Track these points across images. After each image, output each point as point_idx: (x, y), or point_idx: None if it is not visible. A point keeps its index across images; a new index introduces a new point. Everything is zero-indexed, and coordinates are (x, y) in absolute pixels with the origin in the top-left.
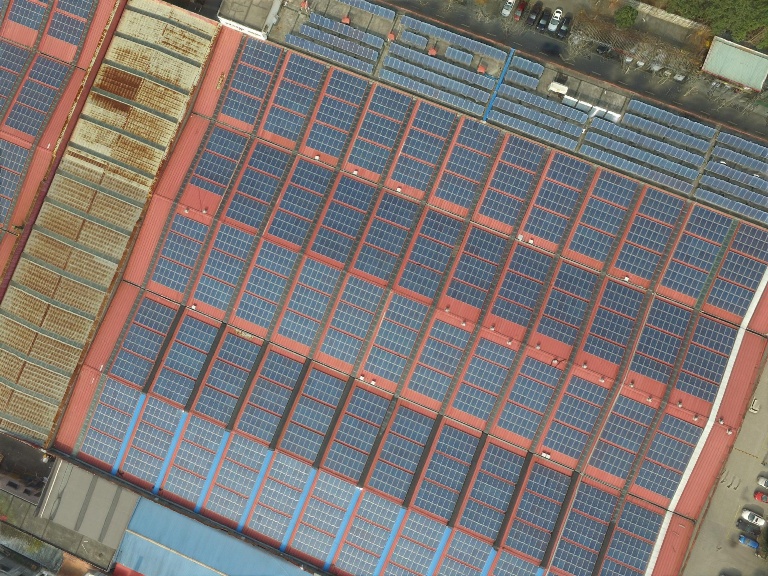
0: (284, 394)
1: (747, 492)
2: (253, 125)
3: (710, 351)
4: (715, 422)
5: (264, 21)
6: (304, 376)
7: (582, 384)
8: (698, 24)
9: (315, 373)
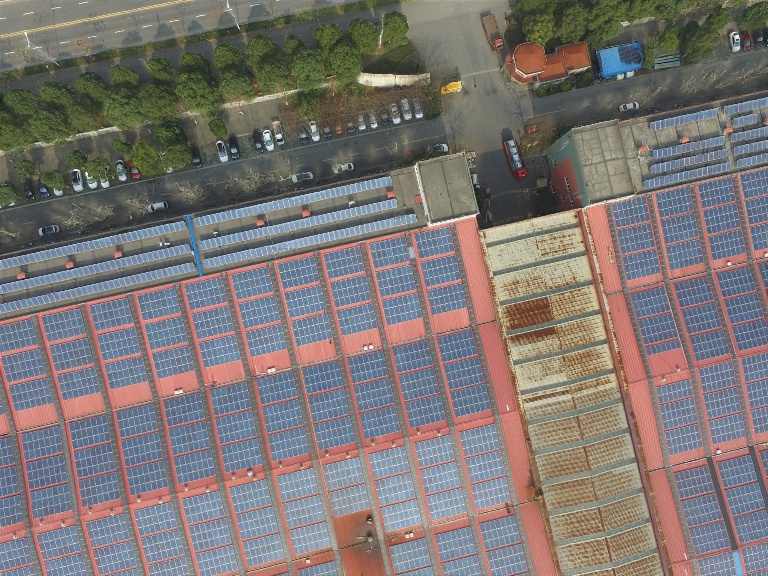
0: None
1: None
2: (660, 272)
3: None
4: None
5: (630, 184)
6: None
7: None
8: None
9: None
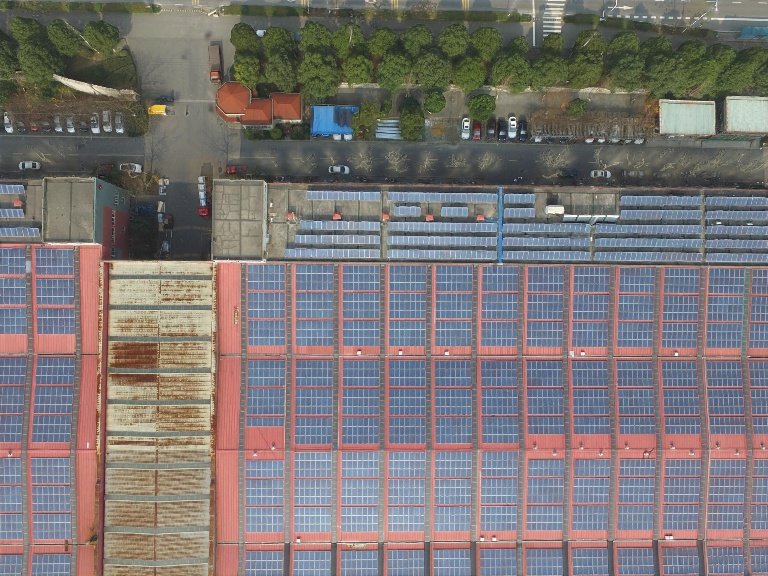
0: None
1: None
2: (285, 345)
3: None
4: None
5: (260, 248)
6: (429, 560)
7: (676, 464)
8: (640, 92)
9: (438, 553)
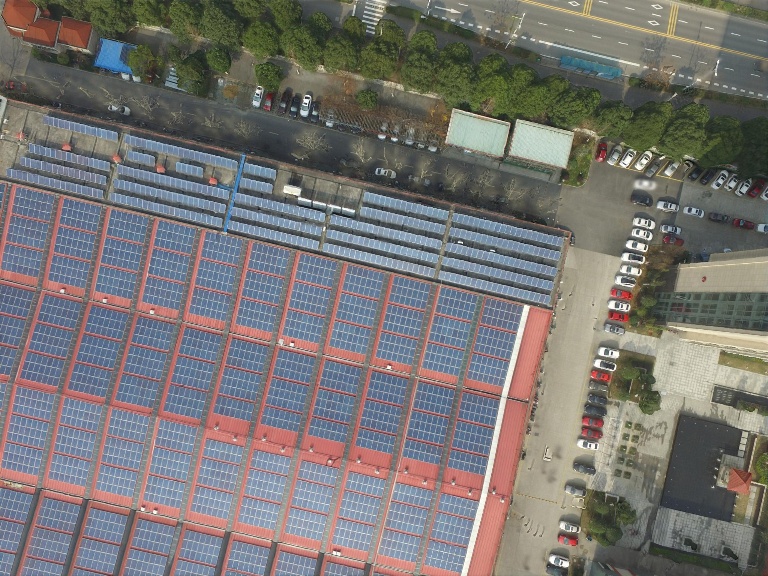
0: (64, 540)
1: (552, 537)
2: None
3: (476, 425)
4: (488, 493)
5: None
6: (83, 518)
7: (359, 479)
8: (437, 97)
9: (94, 513)
